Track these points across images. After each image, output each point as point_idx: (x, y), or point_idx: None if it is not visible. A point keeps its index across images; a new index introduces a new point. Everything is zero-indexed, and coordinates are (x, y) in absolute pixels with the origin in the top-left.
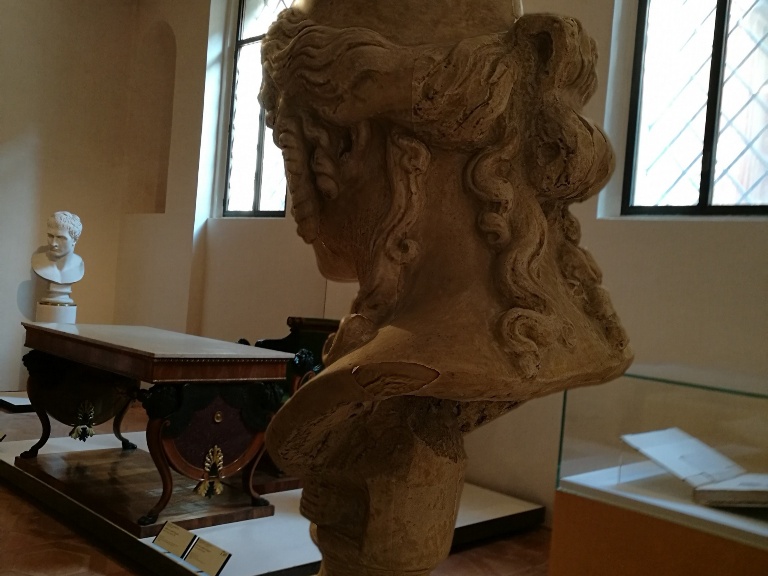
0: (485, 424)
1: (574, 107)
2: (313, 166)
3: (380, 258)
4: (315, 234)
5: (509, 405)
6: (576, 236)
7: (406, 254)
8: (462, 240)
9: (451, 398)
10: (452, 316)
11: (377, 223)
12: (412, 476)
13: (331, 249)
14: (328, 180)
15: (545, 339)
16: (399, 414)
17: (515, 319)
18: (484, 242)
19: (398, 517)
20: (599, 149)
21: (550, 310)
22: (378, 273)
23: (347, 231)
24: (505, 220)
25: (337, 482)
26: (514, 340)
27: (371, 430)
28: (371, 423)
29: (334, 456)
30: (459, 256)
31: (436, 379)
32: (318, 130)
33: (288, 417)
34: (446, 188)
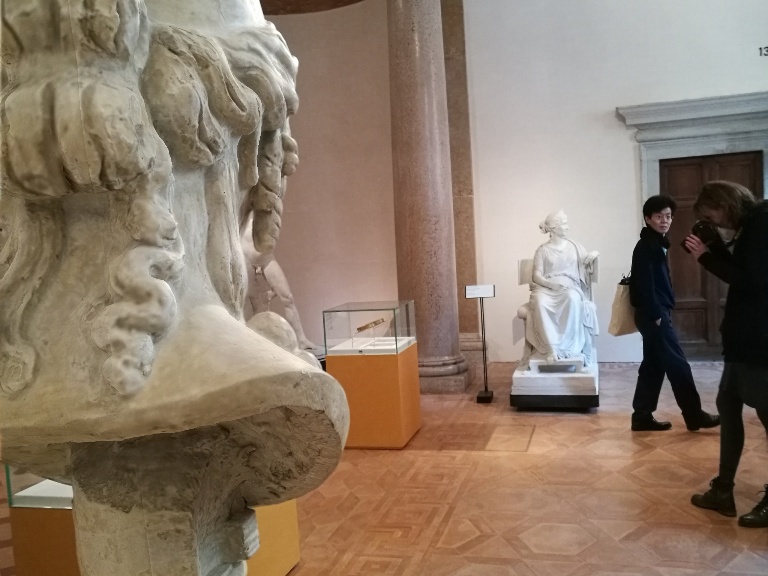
0: (325, 472)
1: (35, 78)
2: None
3: None
4: None
5: (317, 451)
6: (140, 234)
7: None
8: None
9: None
10: None
11: None
12: (78, 517)
13: None
14: None
15: None
16: None
17: None
18: None
19: (81, 558)
20: (23, 129)
21: None
22: None
23: None
24: None
25: None
26: None
27: None
28: None
29: None
30: None
31: None
32: None
33: None
34: None
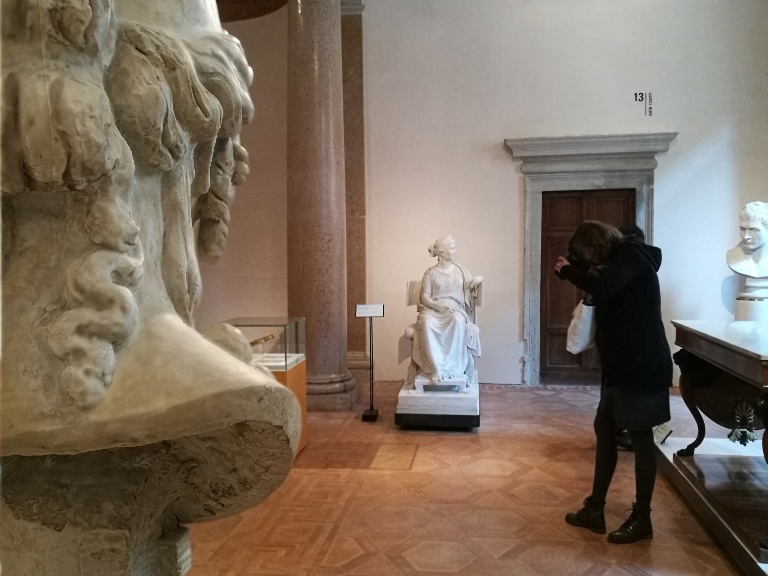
0: (268, 489)
1: None
2: None
3: None
4: None
5: (264, 468)
6: (100, 237)
7: None
8: None
9: None
10: None
11: None
12: (1, 536)
13: None
14: None
15: None
16: None
17: None
18: None
19: None
20: None
21: None
22: None
23: None
24: None
25: None
26: None
27: None
28: None
29: None
30: None
31: None
32: None
33: None
34: None
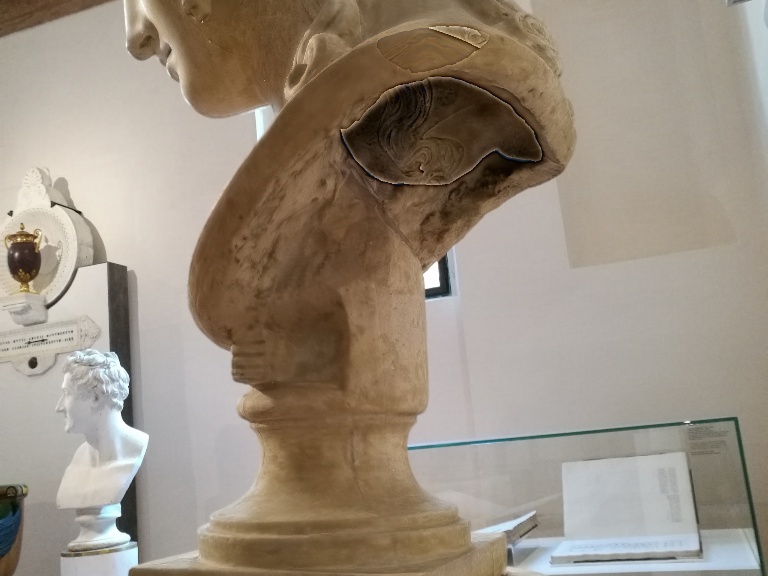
0: None
1: None
2: None
3: None
4: (209, 7)
5: None
6: None
7: None
8: None
9: (497, 79)
10: None
11: None
12: (393, 279)
13: (220, 43)
14: None
15: None
16: (364, 203)
17: (523, 18)
18: None
19: (385, 334)
20: None
21: None
22: None
23: (247, 7)
24: None
25: (285, 319)
26: (533, 34)
27: (330, 230)
28: (328, 221)
29: (284, 274)
30: None
31: None
32: None
33: (263, 160)
34: None
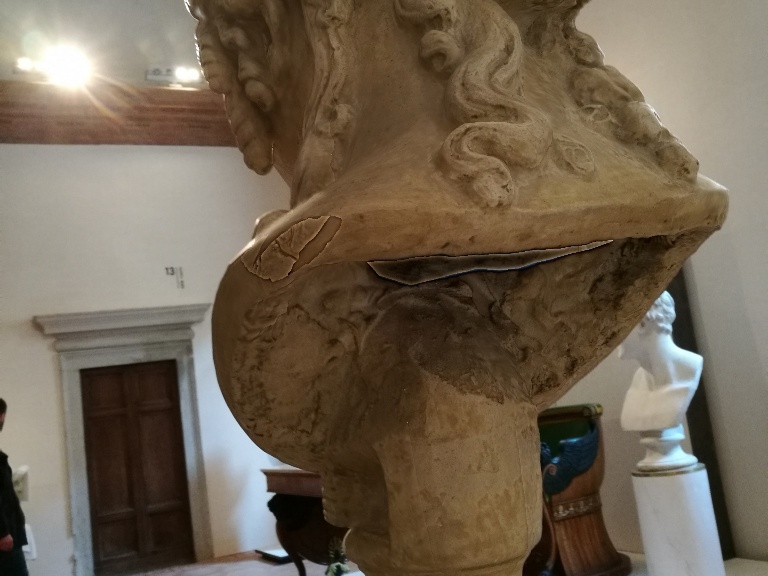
0: (583, 374)
1: None
2: (238, 76)
3: (306, 138)
4: (266, 160)
5: (604, 338)
6: (592, 56)
7: (335, 121)
8: (402, 81)
9: (376, 257)
10: (379, 160)
11: (306, 104)
12: (431, 427)
13: None
14: (255, 84)
15: (518, 154)
16: (396, 346)
17: (462, 134)
18: (432, 74)
19: (426, 489)
20: None
21: (523, 118)
22: (303, 154)
23: None
24: (451, 36)
25: (354, 464)
26: (462, 160)
27: (369, 378)
28: (367, 369)
29: (335, 427)
30: (399, 99)
31: (339, 229)
32: (231, 30)
33: (219, 363)
34: (377, 31)
